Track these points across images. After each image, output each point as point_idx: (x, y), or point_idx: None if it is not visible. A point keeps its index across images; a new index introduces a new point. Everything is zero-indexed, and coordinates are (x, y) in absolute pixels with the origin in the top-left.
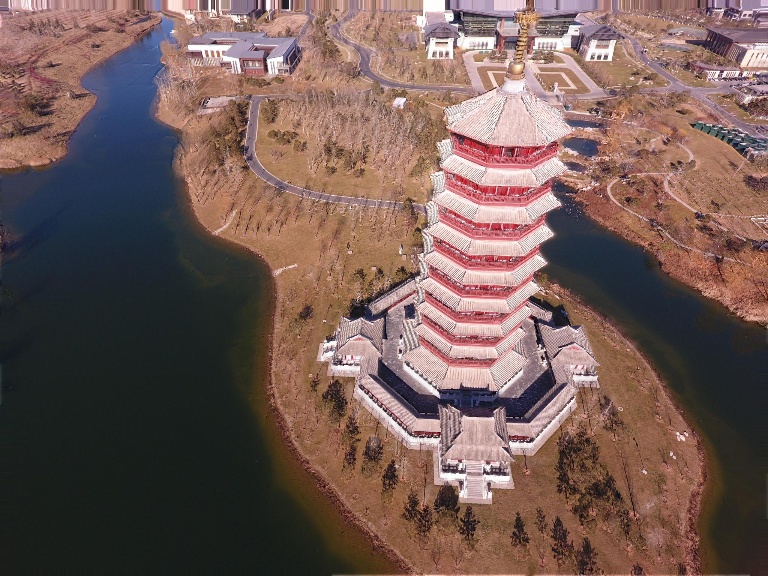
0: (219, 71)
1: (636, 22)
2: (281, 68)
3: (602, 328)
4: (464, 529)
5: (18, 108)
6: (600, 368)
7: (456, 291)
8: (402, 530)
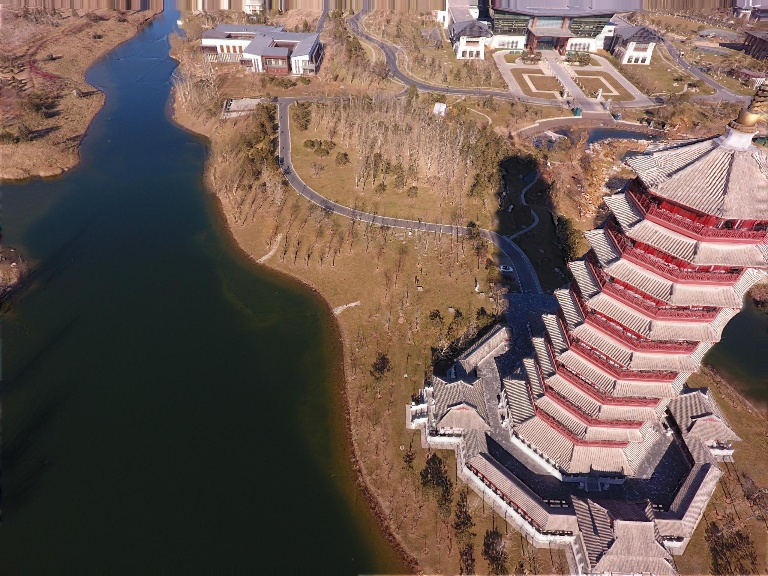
0: (236, 68)
1: (666, 23)
2: (306, 67)
3: (715, 383)
4: None
5: (22, 109)
6: None
7: (611, 372)
8: None
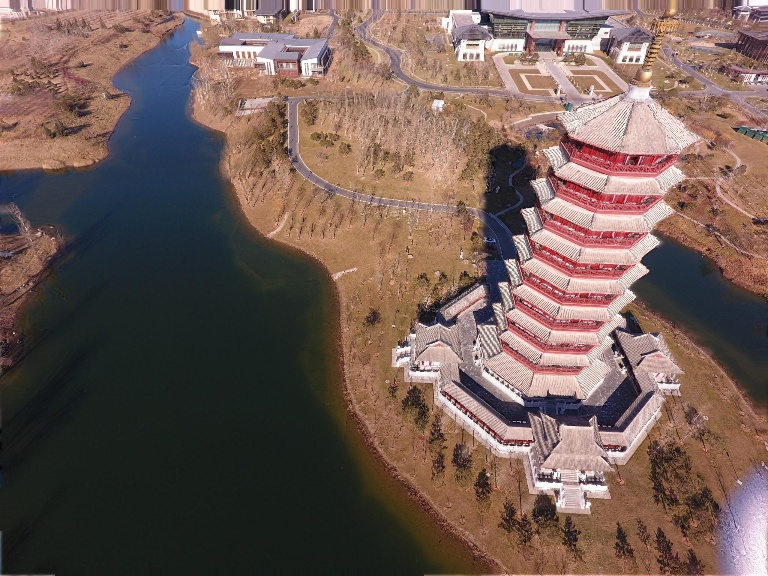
0: (251, 72)
1: None
2: (315, 69)
3: (673, 335)
4: (566, 539)
5: (58, 108)
6: (679, 376)
7: (556, 299)
8: (501, 540)
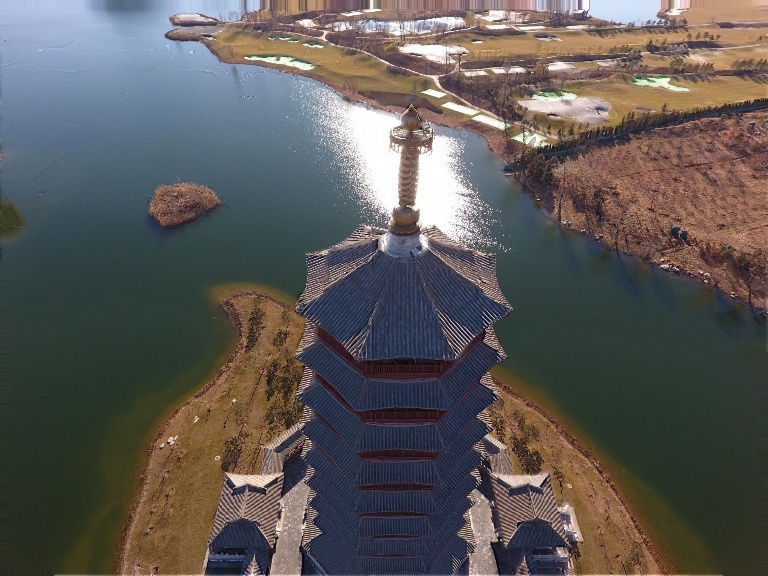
0: None
1: None
2: None
3: None
4: None
5: None
6: (207, 515)
7: None
8: None
